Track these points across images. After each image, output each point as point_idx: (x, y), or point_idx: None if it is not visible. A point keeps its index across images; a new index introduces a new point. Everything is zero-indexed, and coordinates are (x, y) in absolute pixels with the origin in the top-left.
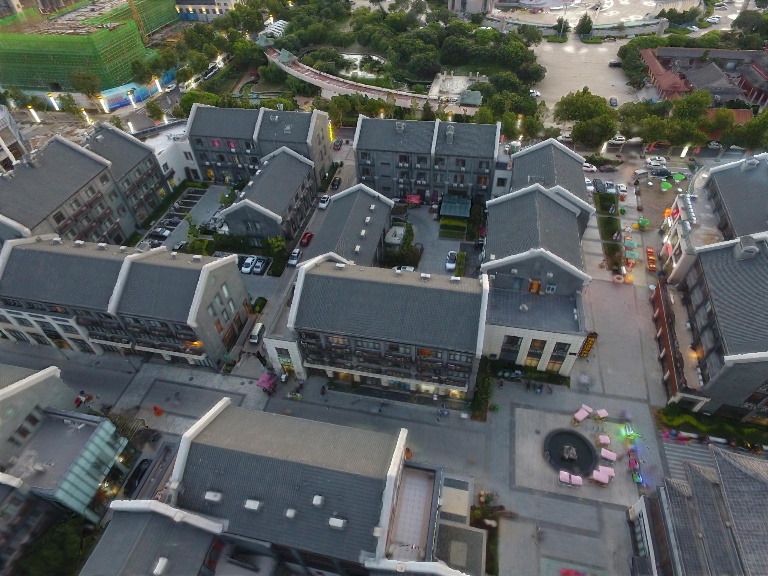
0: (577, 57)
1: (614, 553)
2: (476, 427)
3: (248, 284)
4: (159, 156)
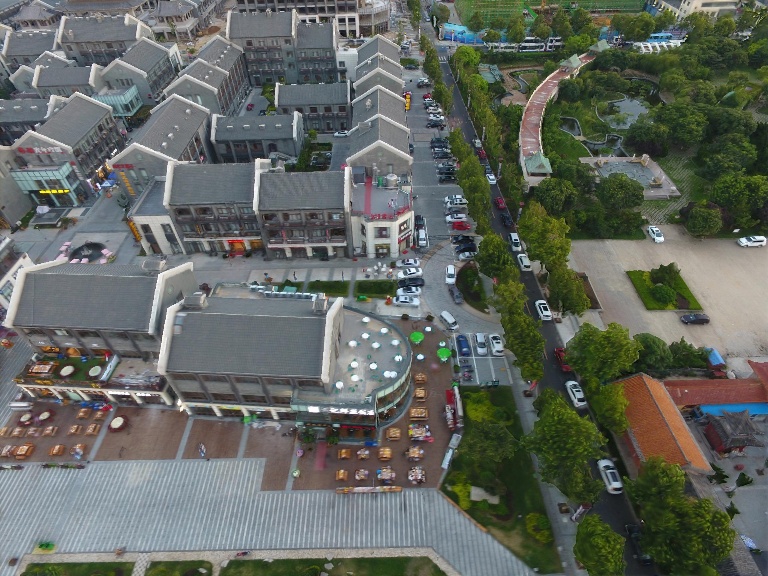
0: None
1: None
2: (119, 217)
3: None
4: (340, 54)
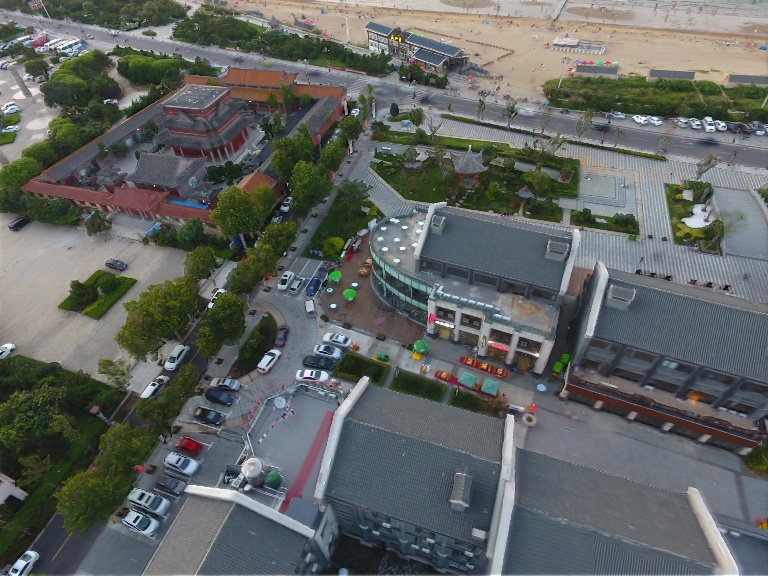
0: None
1: None
2: None
3: None
4: None
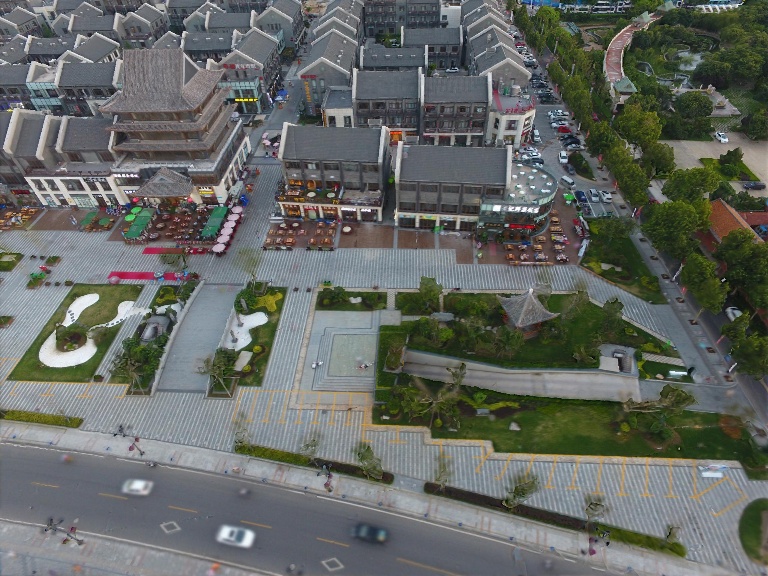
0: None
1: None
2: (294, 121)
3: None
4: (444, 9)
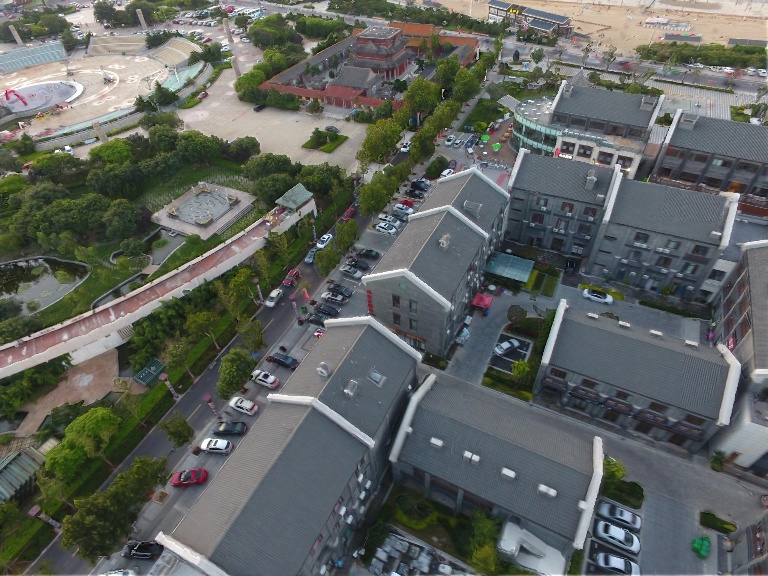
0: (216, 120)
1: None
2: None
3: (665, 544)
4: None
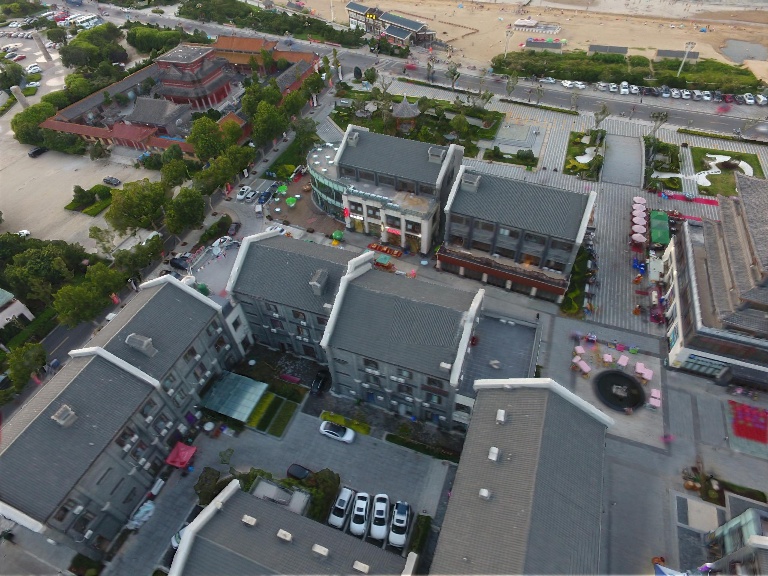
0: None
1: (707, 391)
2: None
3: None
4: None
